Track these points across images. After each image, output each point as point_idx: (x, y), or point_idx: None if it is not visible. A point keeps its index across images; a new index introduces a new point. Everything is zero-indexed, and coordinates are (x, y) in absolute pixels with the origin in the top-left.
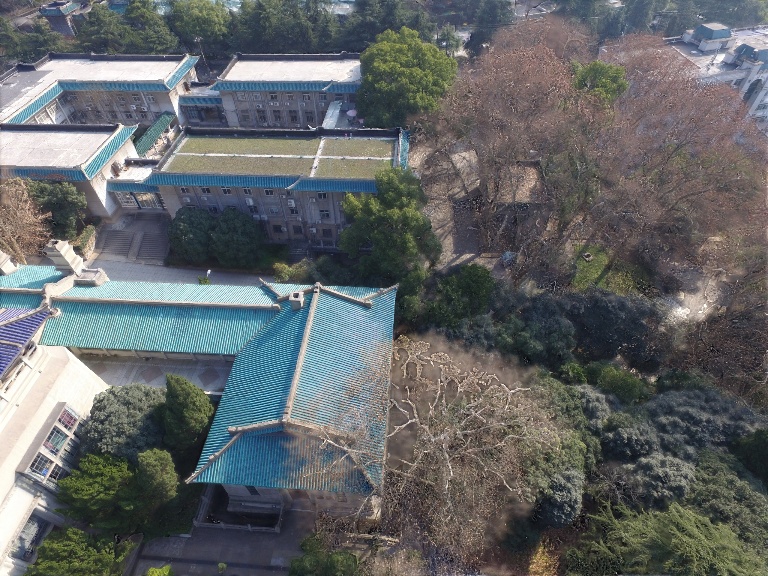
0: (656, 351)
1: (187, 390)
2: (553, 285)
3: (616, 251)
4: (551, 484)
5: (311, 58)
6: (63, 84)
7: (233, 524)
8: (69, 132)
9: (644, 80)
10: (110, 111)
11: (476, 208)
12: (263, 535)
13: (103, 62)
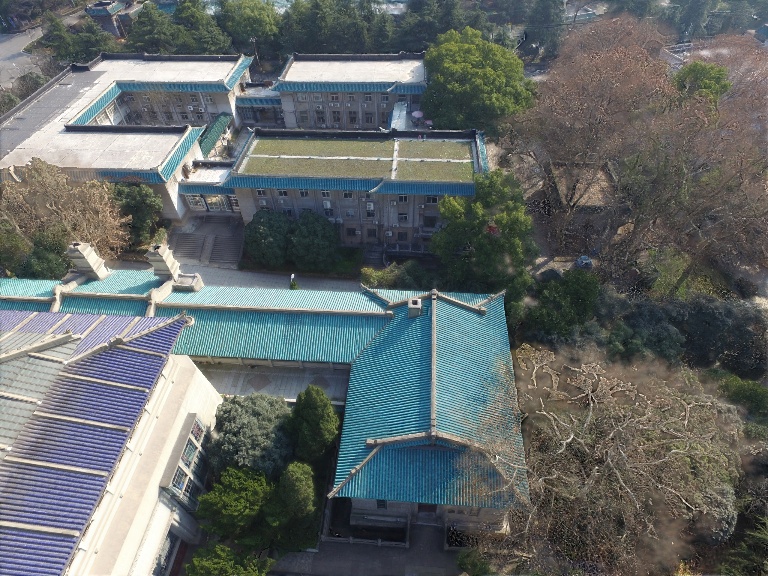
0: (761, 359)
1: (325, 401)
2: (633, 290)
3: (698, 255)
4: (705, 500)
5: (368, 58)
6: (121, 85)
7: None
8: (136, 133)
9: (743, 81)
10: (166, 112)
11: (545, 211)
12: (392, 550)
13: (157, 62)
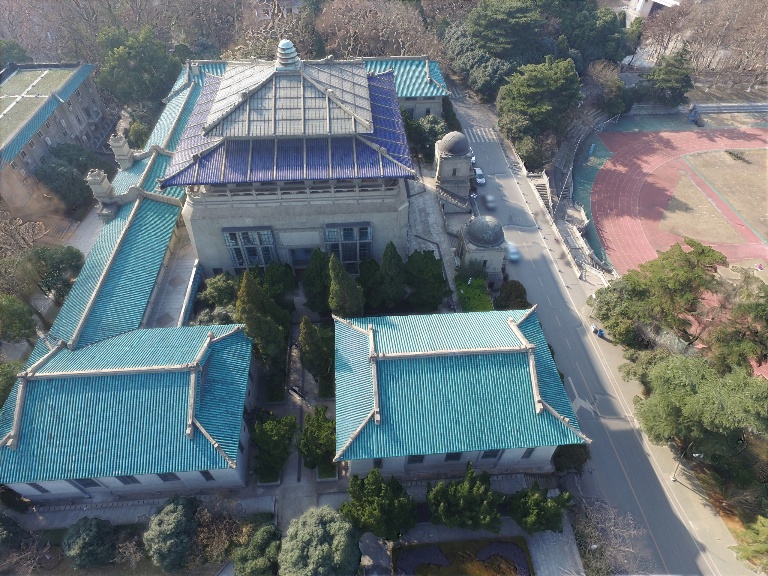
0: None
1: None
2: None
3: None
4: None
5: None
6: None
7: None
8: None
9: None
10: None
11: None
12: None
13: None
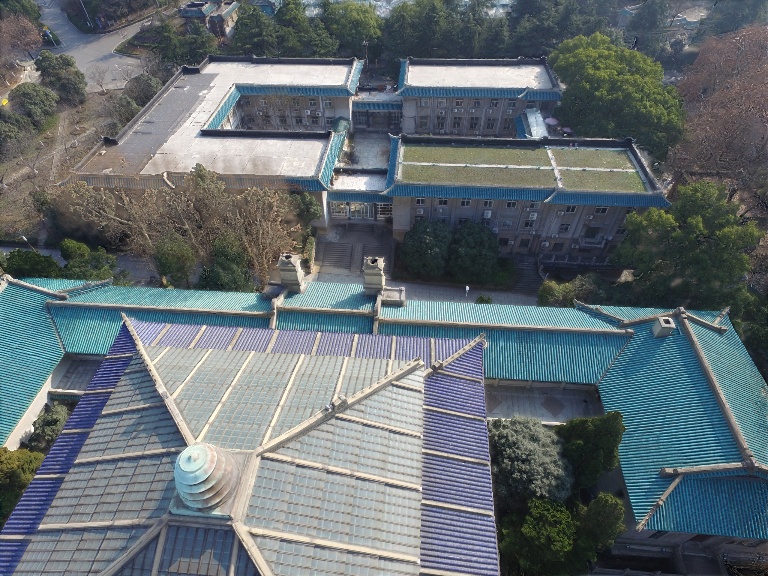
0: None
1: (623, 428)
2: None
3: None
4: None
5: (485, 63)
6: (240, 88)
7: (636, 570)
8: (276, 139)
9: None
10: (280, 116)
11: None
12: None
13: (267, 65)
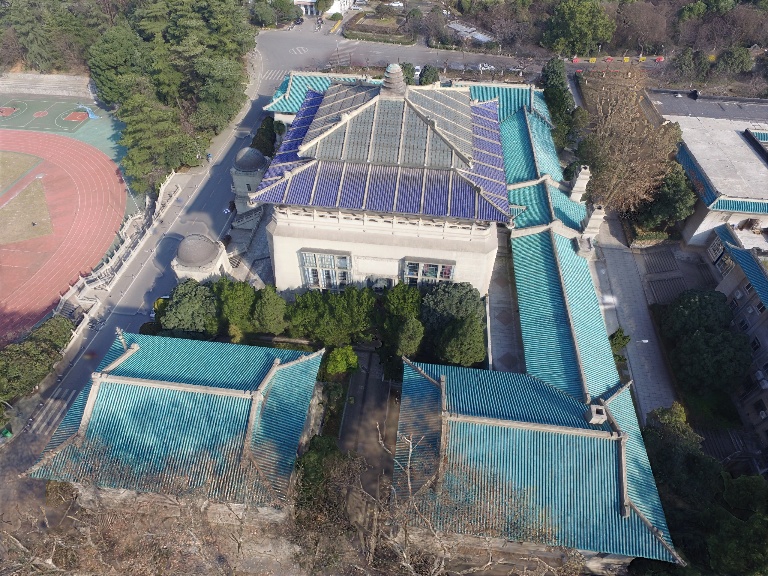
0: None
1: (468, 333)
2: None
3: None
4: None
5: None
6: None
7: (389, 409)
8: None
9: None
10: None
11: None
12: None
13: None
